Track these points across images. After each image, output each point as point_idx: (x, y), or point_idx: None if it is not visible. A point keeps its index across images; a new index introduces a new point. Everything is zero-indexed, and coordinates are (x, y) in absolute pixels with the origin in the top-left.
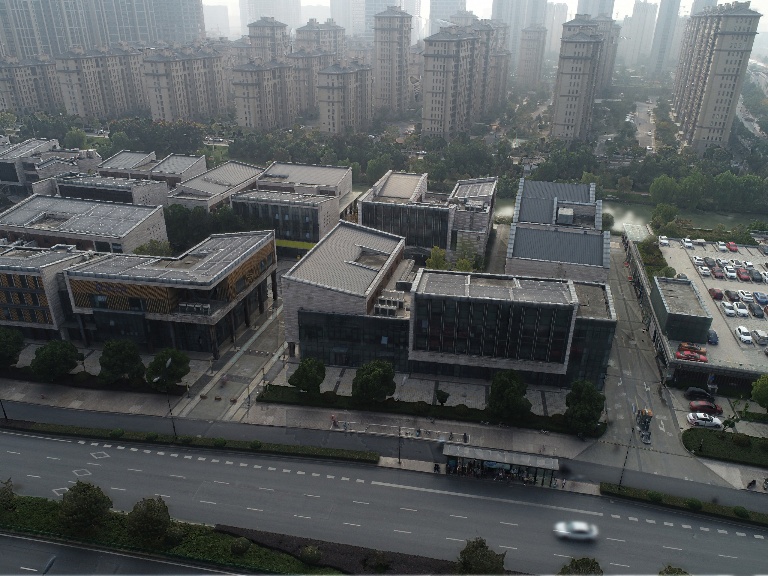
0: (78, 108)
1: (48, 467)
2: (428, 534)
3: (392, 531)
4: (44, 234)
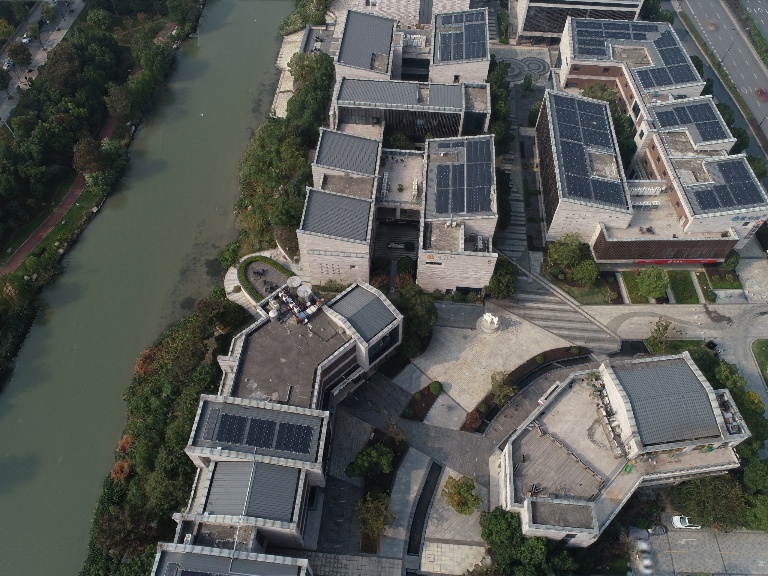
0: None
1: (765, 102)
2: (709, 0)
3: (714, 7)
4: None
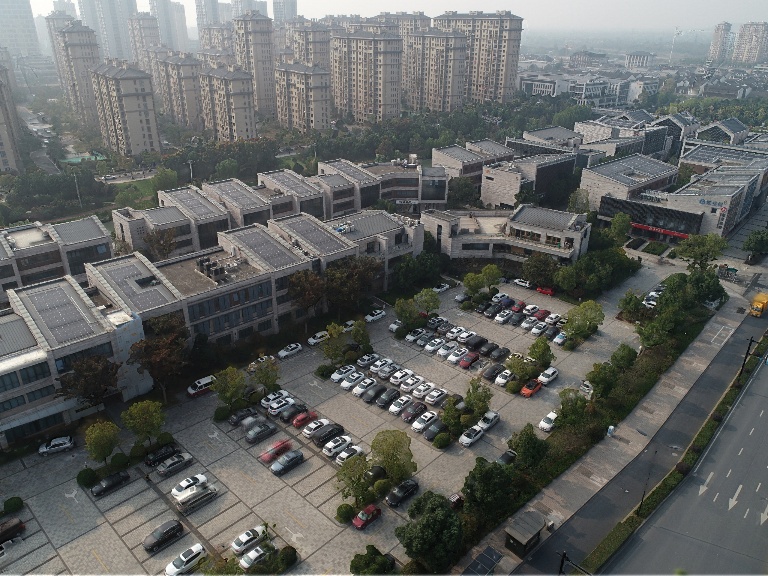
0: (8, 158)
1: None
2: None
3: None
4: (651, 182)
